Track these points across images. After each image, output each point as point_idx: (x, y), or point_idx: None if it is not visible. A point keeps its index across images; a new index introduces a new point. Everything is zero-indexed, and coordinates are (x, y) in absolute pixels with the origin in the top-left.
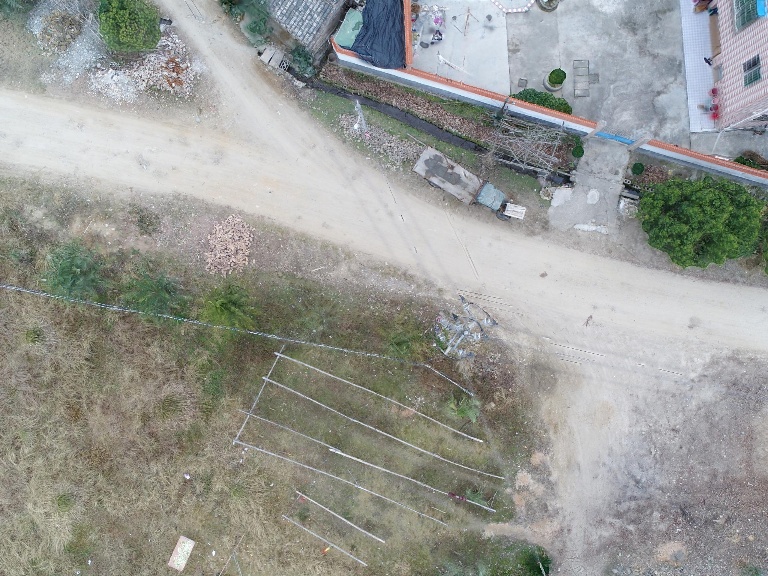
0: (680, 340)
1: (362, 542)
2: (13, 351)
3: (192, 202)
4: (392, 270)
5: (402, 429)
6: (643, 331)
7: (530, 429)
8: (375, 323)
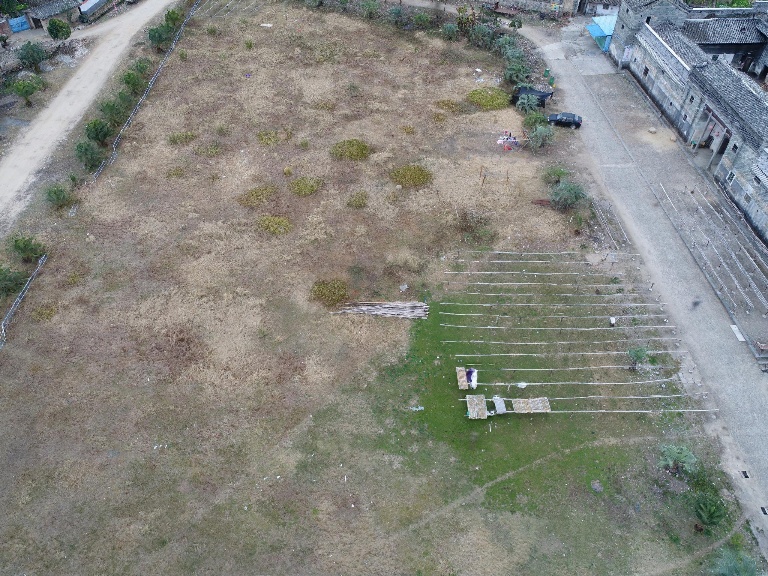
0: None
1: (263, 7)
2: (190, 65)
3: (134, 37)
4: (166, 7)
5: (222, 3)
6: None
7: None
8: (185, 8)
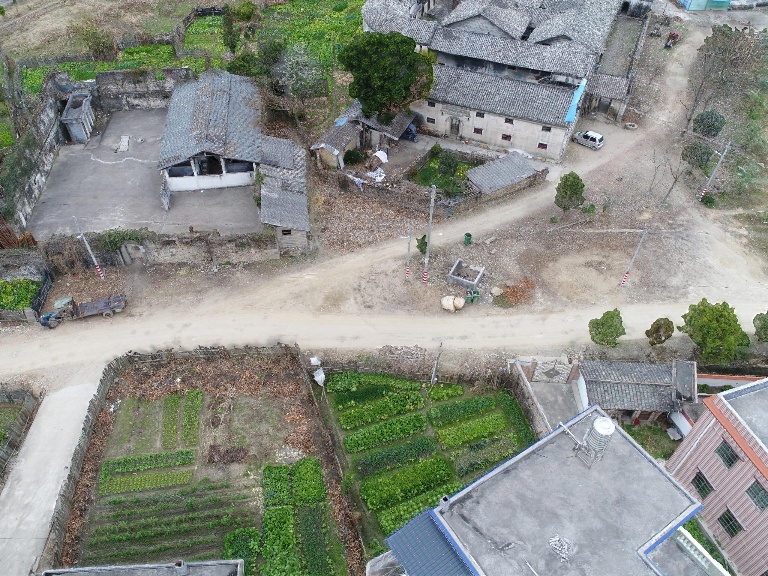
0: (713, 302)
1: None
2: None
3: None
4: None
5: None
6: (738, 303)
7: (759, 251)
8: None
